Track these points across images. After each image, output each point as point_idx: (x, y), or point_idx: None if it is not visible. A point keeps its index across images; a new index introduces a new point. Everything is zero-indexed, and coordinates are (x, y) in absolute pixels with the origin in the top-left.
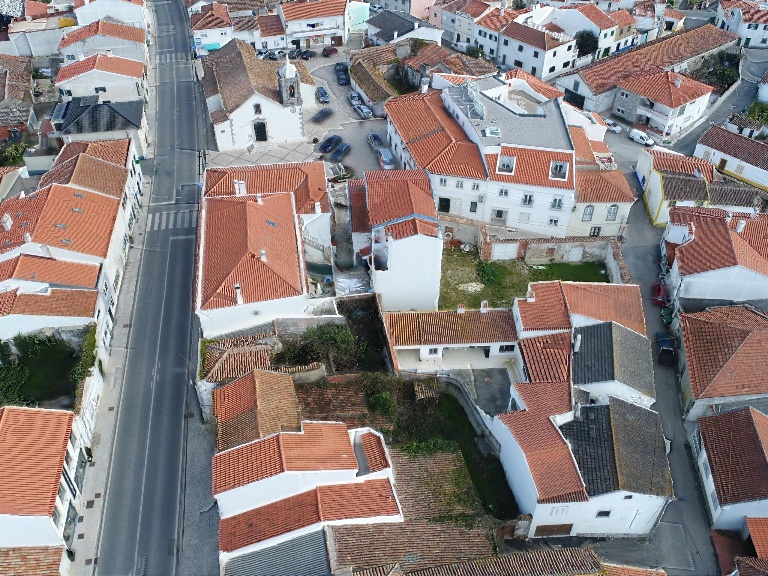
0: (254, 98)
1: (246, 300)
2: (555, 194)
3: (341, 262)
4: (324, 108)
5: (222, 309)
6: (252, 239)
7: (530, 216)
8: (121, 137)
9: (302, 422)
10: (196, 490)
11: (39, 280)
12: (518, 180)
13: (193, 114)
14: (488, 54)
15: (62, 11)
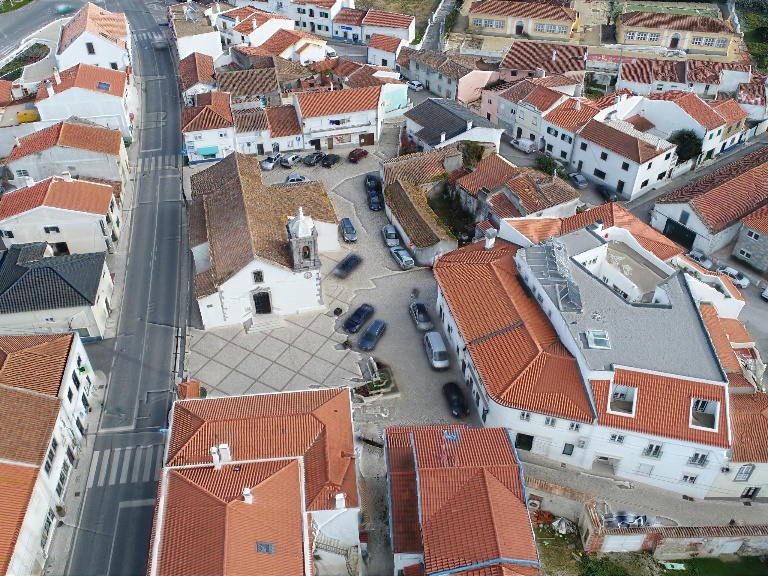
0: (253, 265)
1: None
2: (697, 448)
3: (374, 571)
4: (350, 251)
5: None
6: None
7: (654, 469)
8: (68, 315)
9: None
10: None
11: None
12: (641, 426)
13: (176, 258)
14: (558, 157)
15: (25, 98)
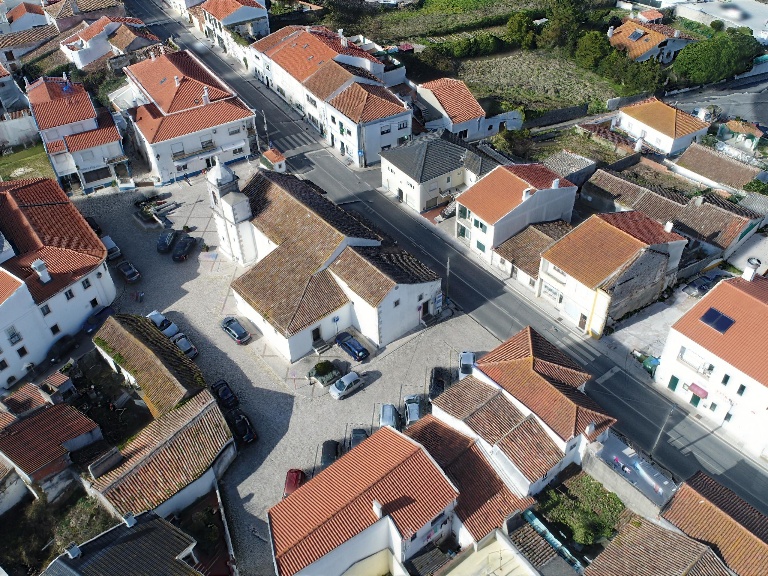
0: None
1: None
2: None
3: (129, 143)
4: (225, 312)
5: None
6: None
7: None
8: None
9: None
10: None
11: (292, 38)
12: None
13: None
14: None
15: None
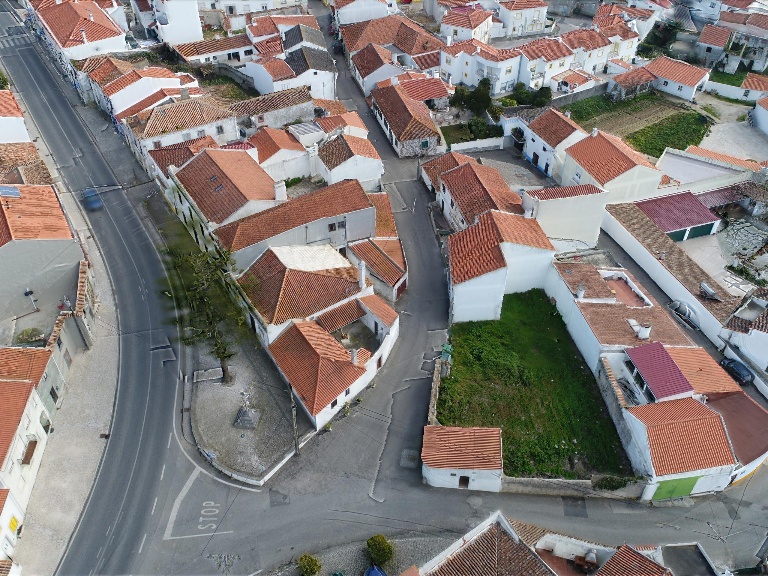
0: None
1: (89, 41)
2: None
3: None
4: None
5: (76, 46)
6: (81, 14)
7: (250, 6)
8: None
9: (144, 67)
10: (94, 125)
11: None
12: None
13: None
14: None
15: None
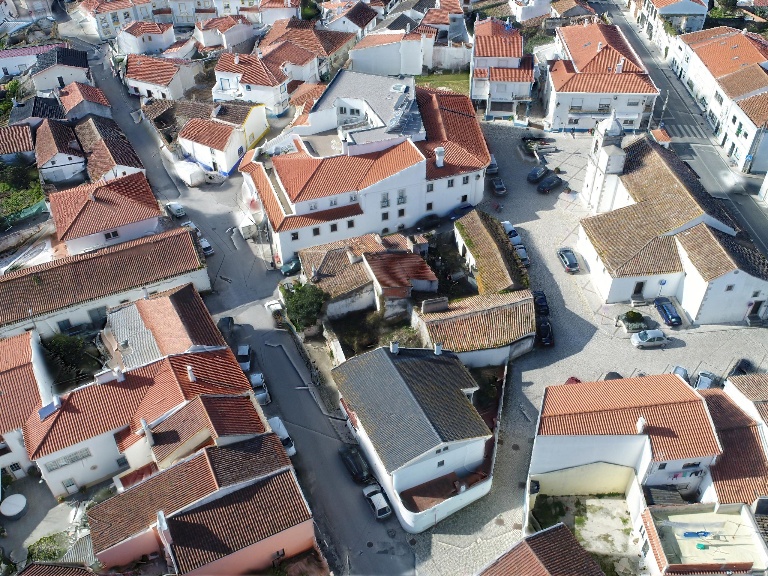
0: None
1: None
2: None
3: (535, 91)
4: (564, 244)
5: None
6: None
7: None
8: None
9: None
10: None
11: (724, 37)
12: None
13: None
14: None
15: None
